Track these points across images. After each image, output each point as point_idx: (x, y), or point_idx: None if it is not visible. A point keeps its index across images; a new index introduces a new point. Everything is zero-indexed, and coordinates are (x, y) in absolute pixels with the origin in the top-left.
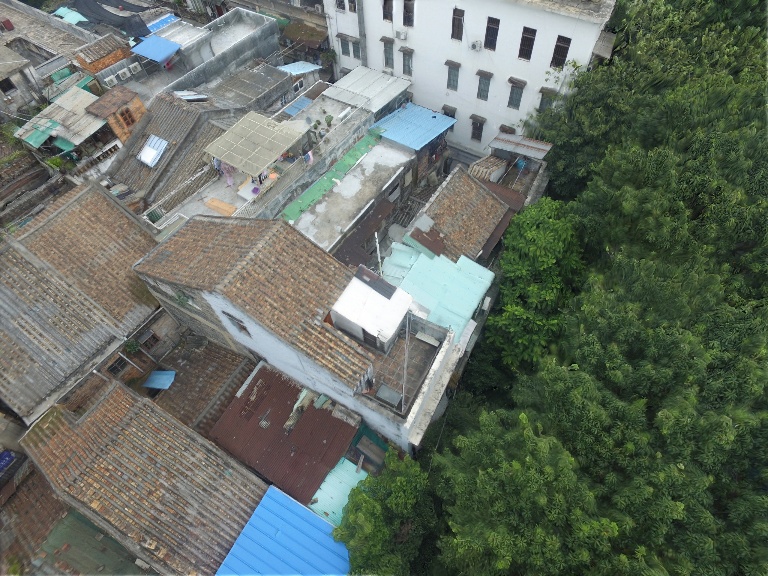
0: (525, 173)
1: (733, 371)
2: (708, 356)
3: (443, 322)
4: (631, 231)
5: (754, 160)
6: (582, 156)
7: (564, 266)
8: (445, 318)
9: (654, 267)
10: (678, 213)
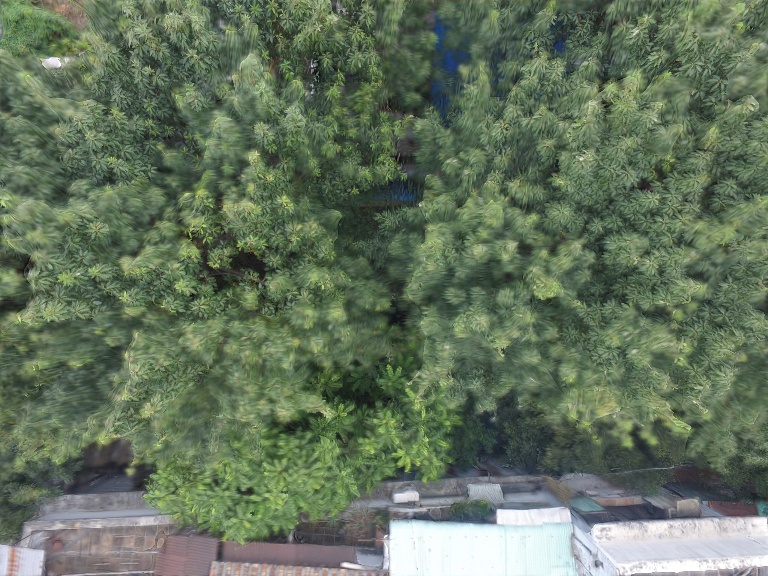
0: (60, 548)
1: (763, 168)
2: (752, 208)
3: (532, 567)
4: (310, 360)
5: (60, 178)
6: (3, 473)
7: (302, 413)
8: (522, 567)
9: (487, 318)
10: (266, 294)
